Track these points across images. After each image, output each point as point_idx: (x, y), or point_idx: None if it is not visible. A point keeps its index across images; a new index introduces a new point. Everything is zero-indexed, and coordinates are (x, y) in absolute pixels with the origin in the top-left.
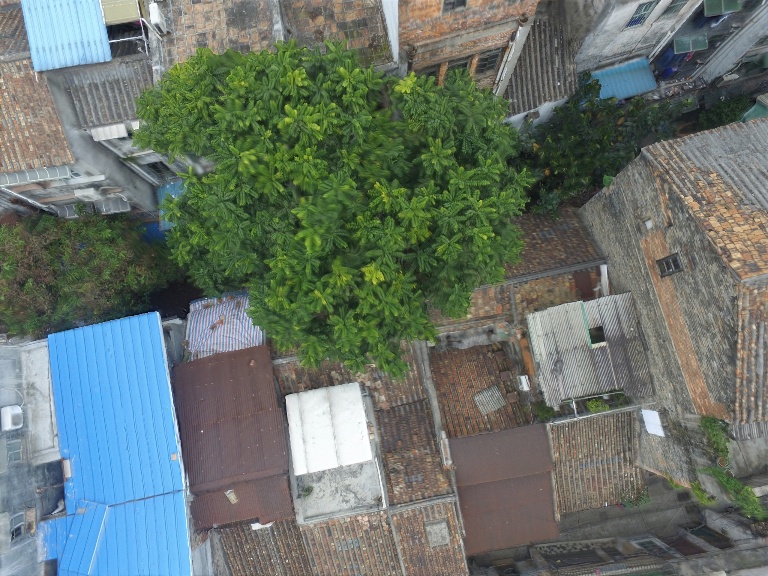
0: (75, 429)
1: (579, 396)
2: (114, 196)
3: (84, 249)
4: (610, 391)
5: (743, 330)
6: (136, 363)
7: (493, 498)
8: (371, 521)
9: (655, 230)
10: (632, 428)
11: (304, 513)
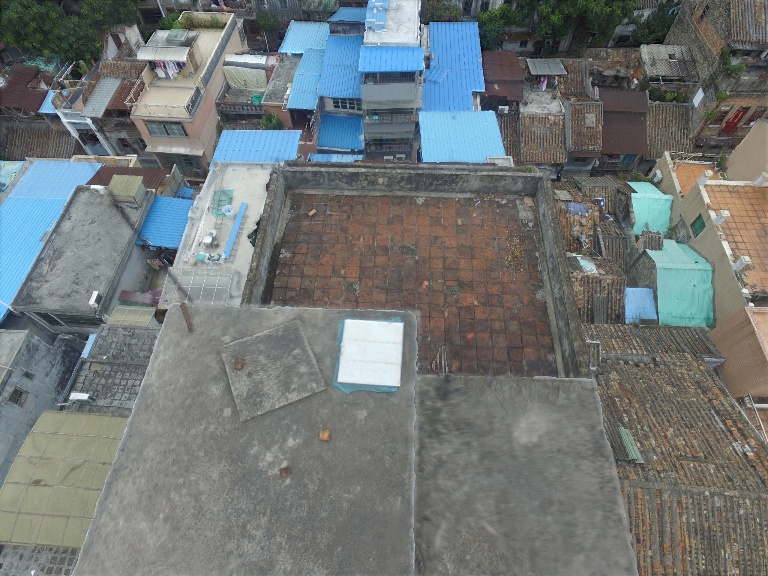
0: (438, 47)
1: (663, 75)
2: (454, 2)
3: (447, 4)
4: (678, 76)
5: (732, 2)
6: (466, 34)
7: (615, 127)
8: (555, 119)
9: (699, 5)
10: (688, 115)
11: (523, 110)
